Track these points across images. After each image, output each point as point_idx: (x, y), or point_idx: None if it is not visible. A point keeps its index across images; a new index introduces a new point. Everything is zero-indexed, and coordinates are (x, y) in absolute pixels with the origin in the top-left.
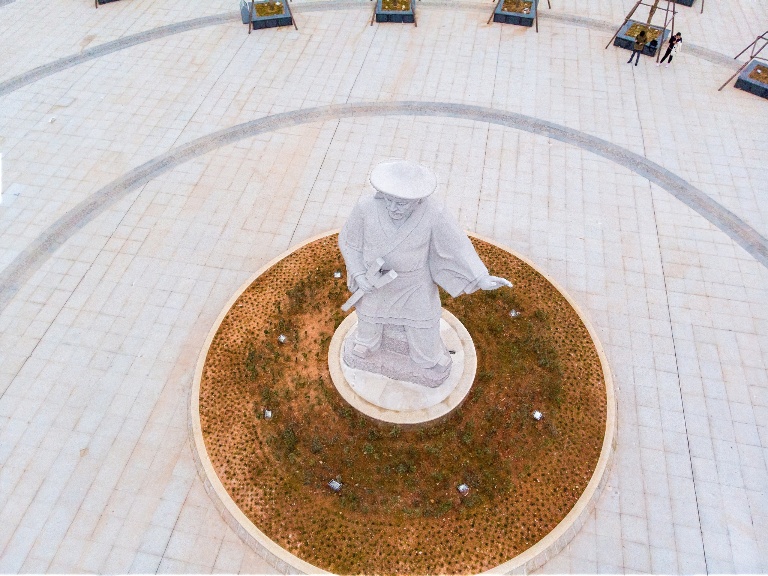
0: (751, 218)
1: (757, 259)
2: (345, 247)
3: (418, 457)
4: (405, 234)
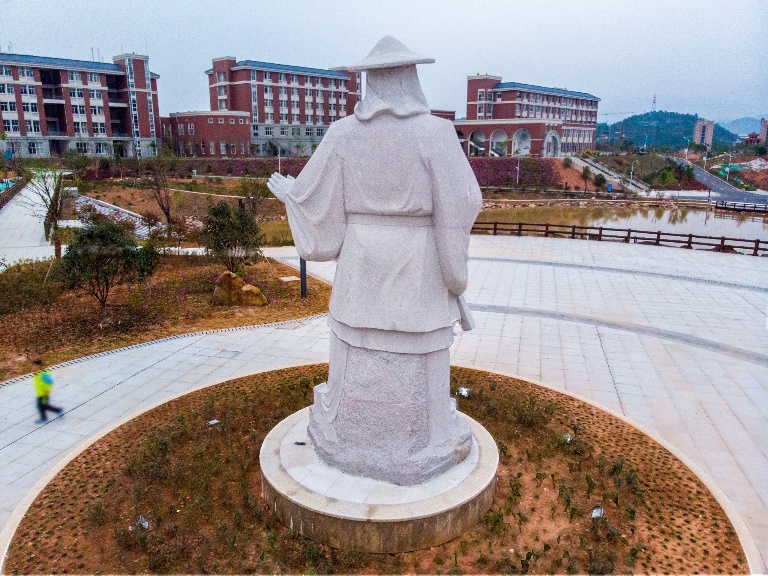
0: None
1: None
2: None
3: None
4: None
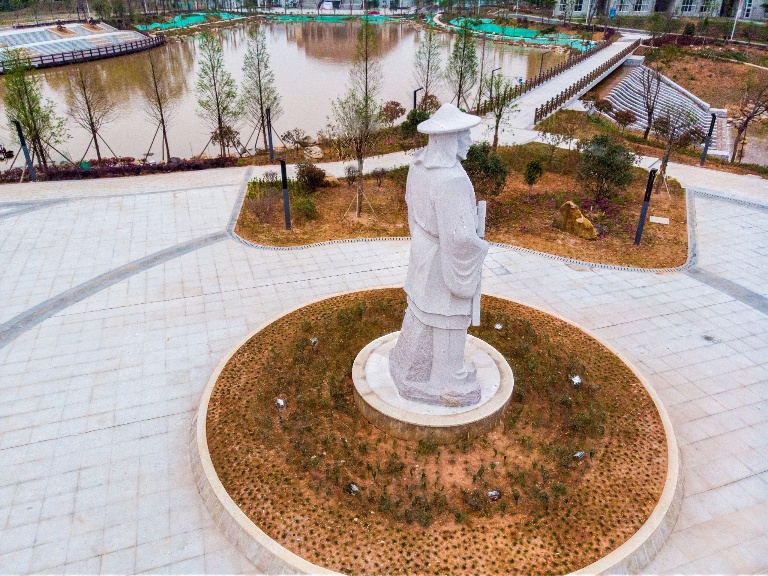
0: (106, 268)
1: (162, 263)
2: None
3: None
4: None
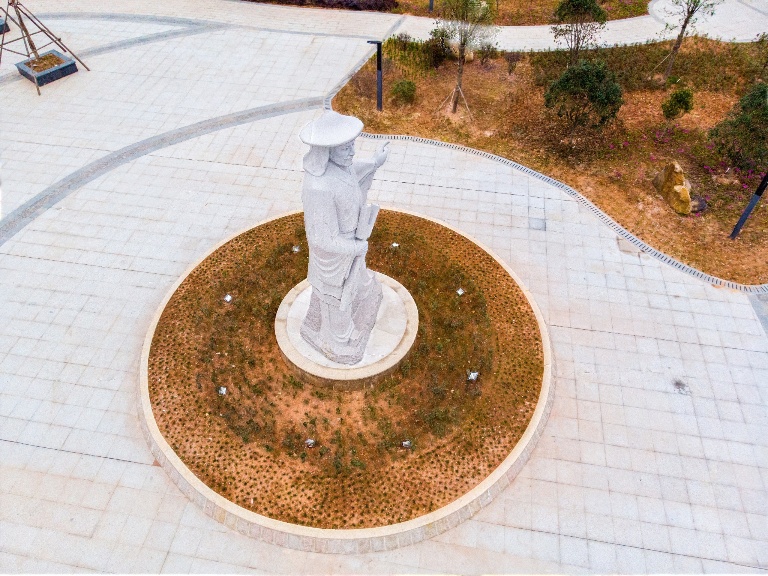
0: (209, 115)
1: (252, 121)
2: (334, 243)
3: None
4: (353, 174)
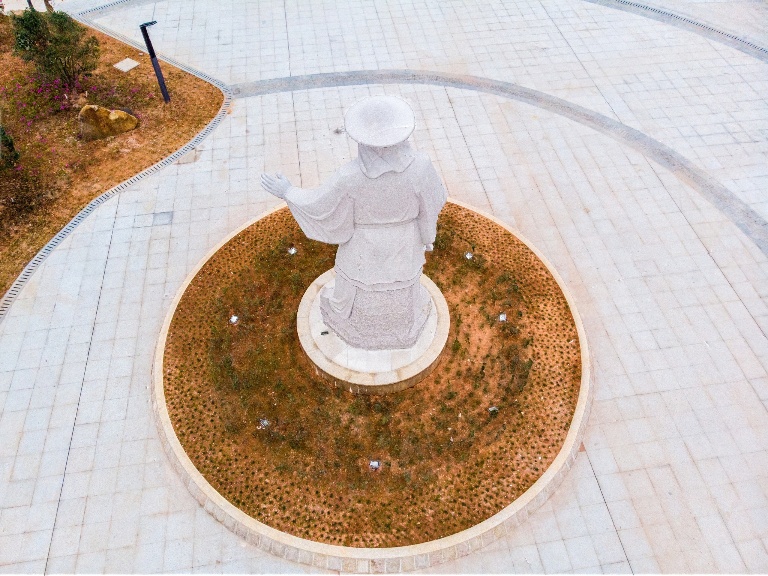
0: None
1: None
2: None
3: (333, 259)
4: None
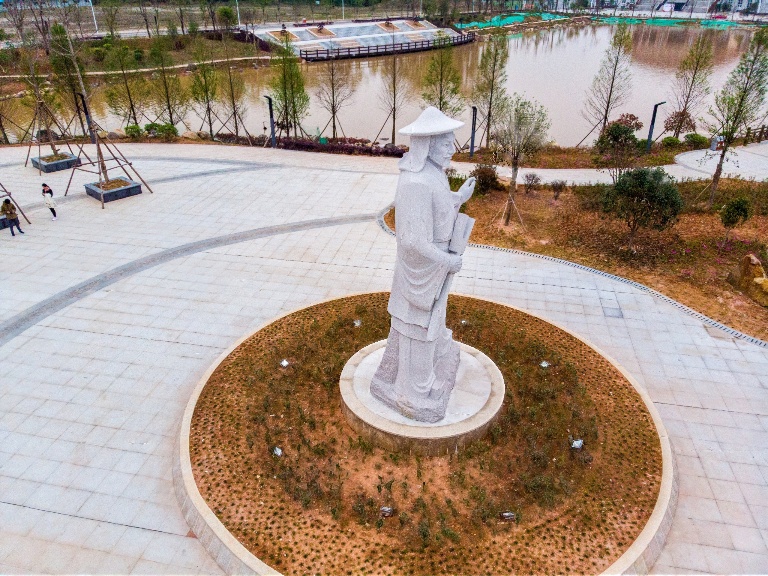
0: (265, 224)
1: (306, 229)
2: (430, 246)
3: None
4: None
